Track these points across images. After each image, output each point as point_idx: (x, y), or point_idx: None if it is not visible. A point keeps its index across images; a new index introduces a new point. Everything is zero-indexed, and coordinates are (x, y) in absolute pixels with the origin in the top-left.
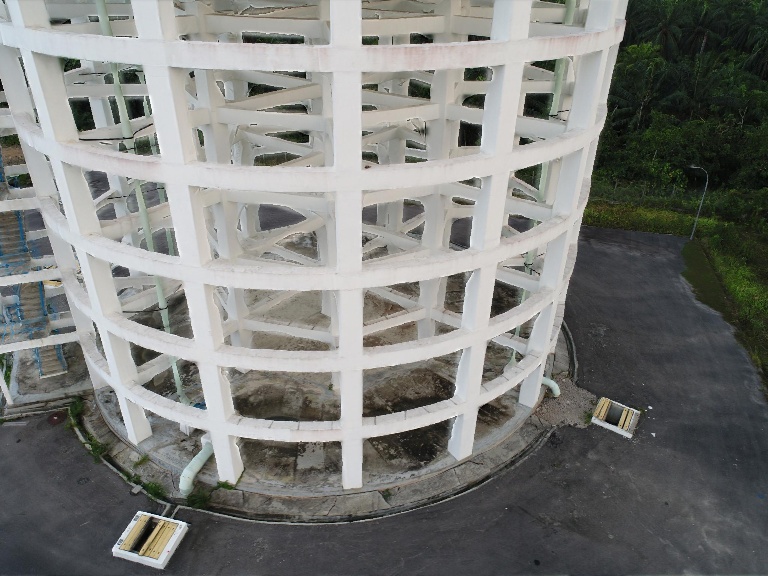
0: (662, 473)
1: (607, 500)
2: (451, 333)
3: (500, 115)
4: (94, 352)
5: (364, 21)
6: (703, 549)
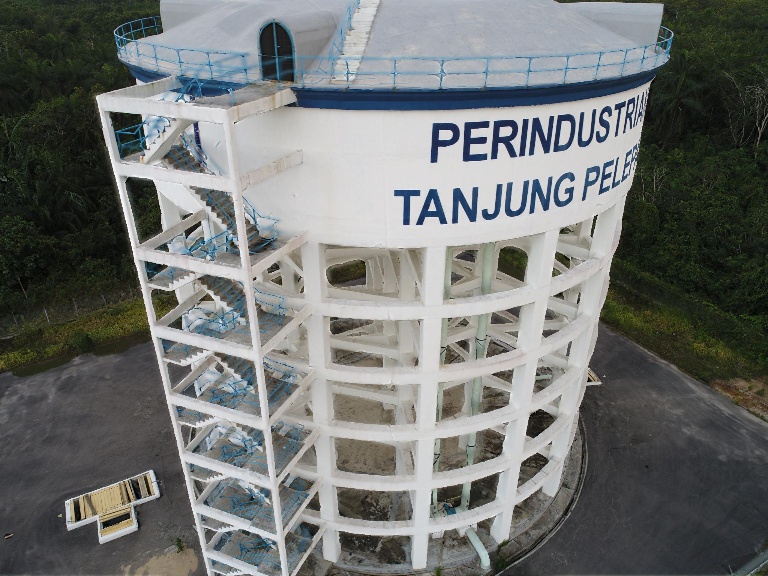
0: (629, 393)
1: (630, 420)
2: None
3: None
4: (370, 523)
5: None
6: (676, 416)
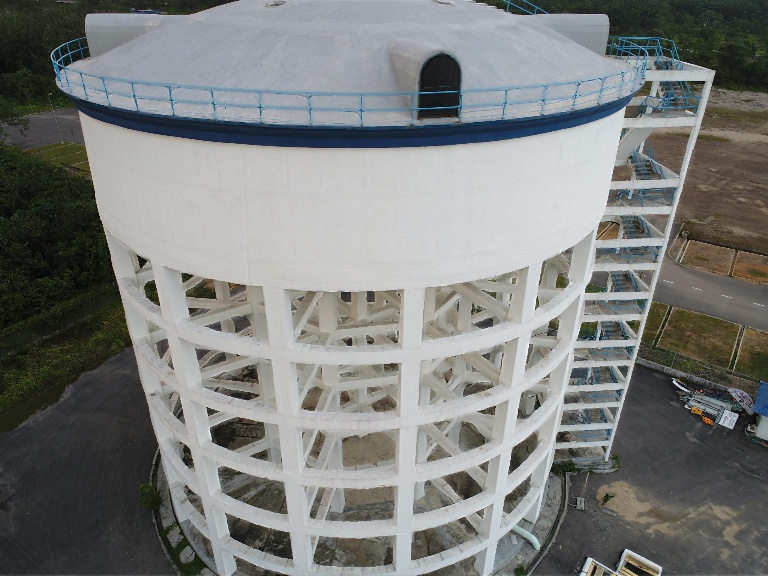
0: None
1: None
2: None
3: None
4: None
5: None
6: None
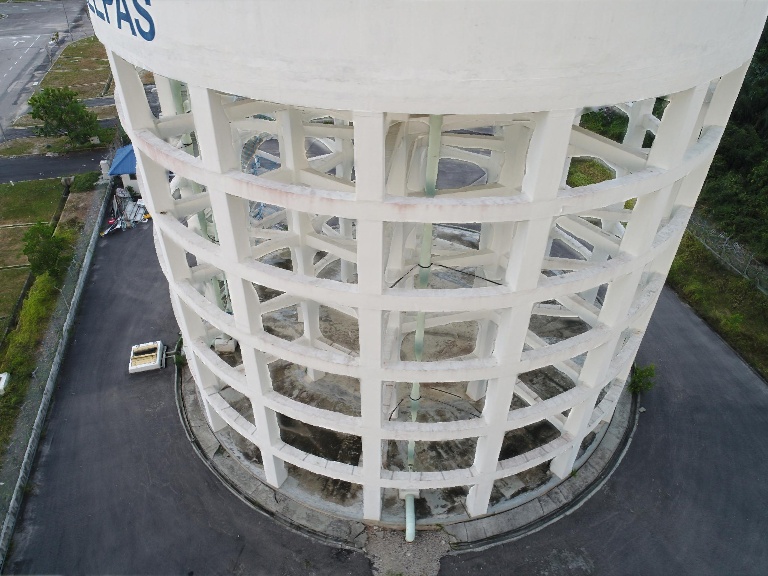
0: None
1: None
2: (241, 376)
3: (217, 226)
4: None
5: None
6: None
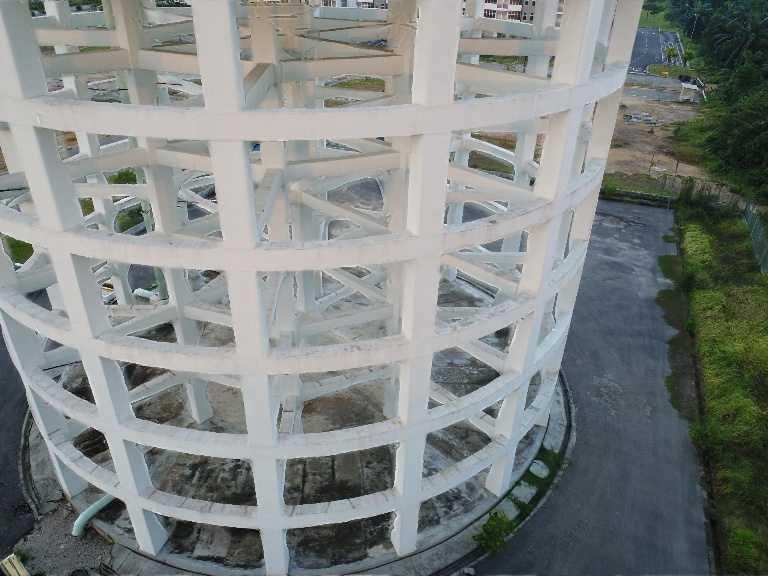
0: None
1: None
2: None
3: None
4: None
5: None
6: None
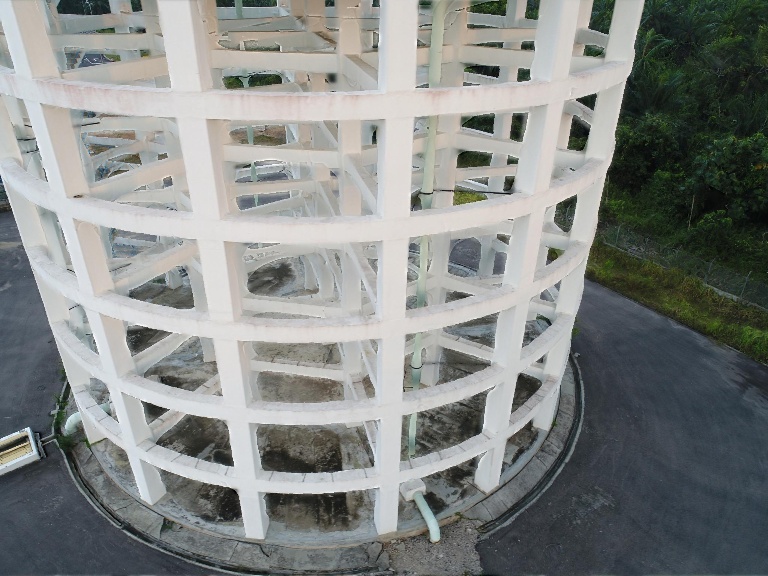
0: None
1: None
2: (208, 396)
3: (188, 174)
4: None
5: (236, 52)
6: None
